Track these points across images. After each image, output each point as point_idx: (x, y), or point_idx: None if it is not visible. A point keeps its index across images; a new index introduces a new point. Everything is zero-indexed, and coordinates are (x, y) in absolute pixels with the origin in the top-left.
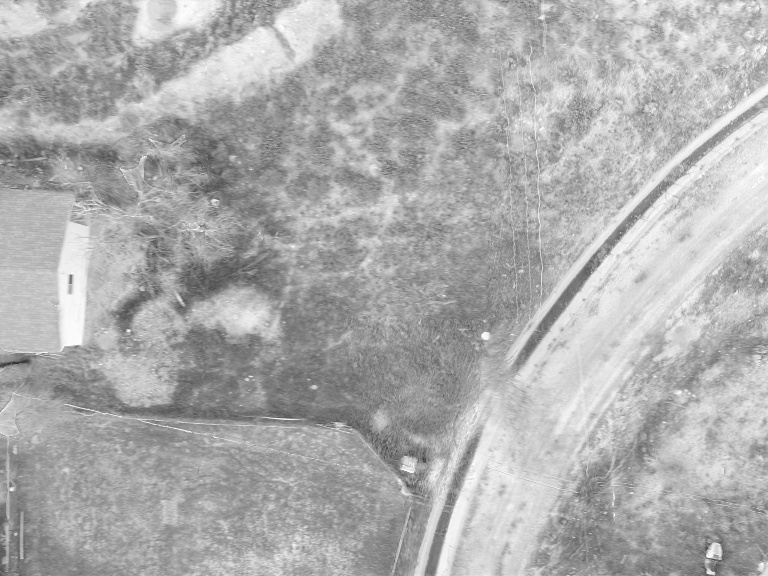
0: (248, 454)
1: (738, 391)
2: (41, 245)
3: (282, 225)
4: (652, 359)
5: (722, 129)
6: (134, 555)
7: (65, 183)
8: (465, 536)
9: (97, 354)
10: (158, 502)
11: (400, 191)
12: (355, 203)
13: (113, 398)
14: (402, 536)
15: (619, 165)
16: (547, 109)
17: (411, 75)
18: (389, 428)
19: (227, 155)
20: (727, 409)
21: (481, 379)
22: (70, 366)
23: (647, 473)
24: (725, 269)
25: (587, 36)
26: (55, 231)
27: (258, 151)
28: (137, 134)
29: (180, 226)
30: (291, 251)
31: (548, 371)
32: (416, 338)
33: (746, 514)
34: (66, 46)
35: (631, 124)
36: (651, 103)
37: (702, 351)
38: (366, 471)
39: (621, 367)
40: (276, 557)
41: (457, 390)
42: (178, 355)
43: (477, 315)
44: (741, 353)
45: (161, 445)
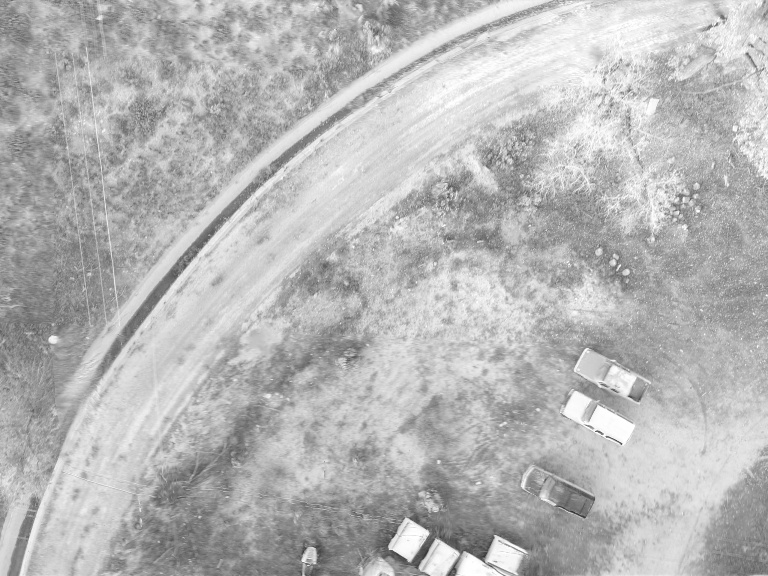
0: None
1: (334, 394)
2: None
3: None
4: (227, 363)
5: (313, 130)
6: None
7: None
8: (40, 541)
9: None
10: None
11: None
12: None
13: None
14: None
15: (190, 167)
16: (107, 111)
17: None
18: None
19: None
20: (324, 412)
21: (55, 383)
22: None
23: (243, 477)
24: (303, 272)
25: (150, 37)
26: None
27: None
28: None
29: None
30: None
31: (124, 375)
32: None
33: (345, 518)
34: None
35: (202, 126)
36: (217, 104)
37: (289, 354)
38: None
39: (196, 371)
40: None
41: (27, 394)
42: None
43: (44, 319)
44: (335, 356)
45: None
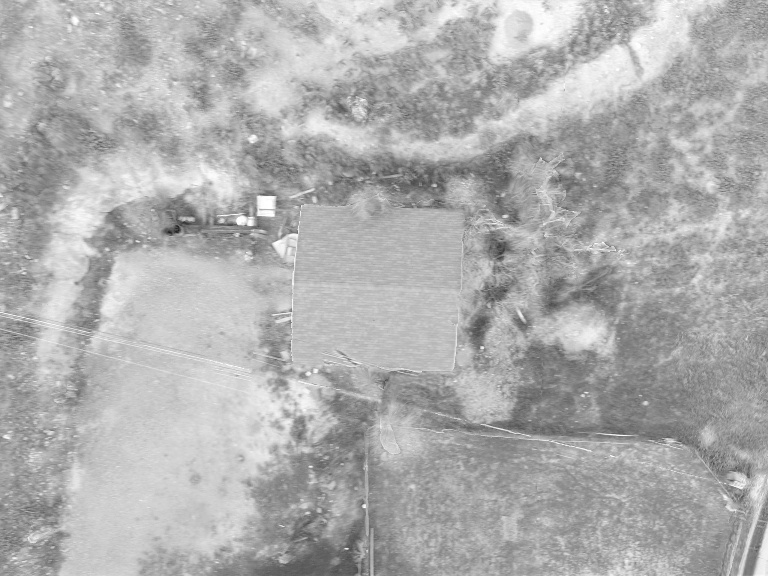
0: (583, 470)
1: None
2: (441, 264)
3: (620, 242)
4: None
5: None
6: (477, 571)
7: (449, 201)
8: None
9: (455, 371)
10: (499, 518)
11: (734, 208)
12: (691, 220)
13: (458, 415)
14: (734, 552)
15: None
16: None
17: (750, 92)
18: (716, 444)
19: (574, 172)
20: None
21: None
22: (427, 383)
23: None
24: None
25: None
26: (452, 250)
27: (603, 168)
28: (492, 151)
29: (566, 245)
30: (626, 267)
31: None
32: (743, 354)
33: None
34: (427, 64)
35: None
36: None
37: None
38: (693, 487)
39: None
40: (610, 573)
41: None
42: (519, 371)
43: None
44: None
45: (501, 461)
